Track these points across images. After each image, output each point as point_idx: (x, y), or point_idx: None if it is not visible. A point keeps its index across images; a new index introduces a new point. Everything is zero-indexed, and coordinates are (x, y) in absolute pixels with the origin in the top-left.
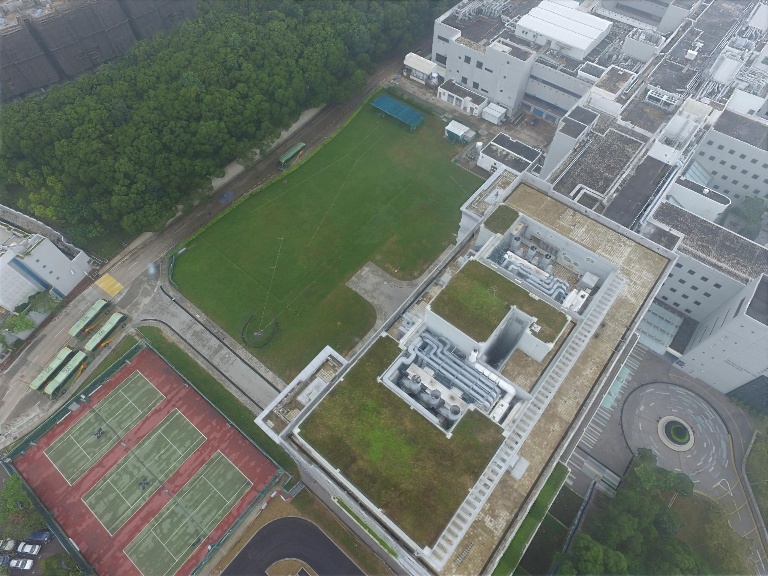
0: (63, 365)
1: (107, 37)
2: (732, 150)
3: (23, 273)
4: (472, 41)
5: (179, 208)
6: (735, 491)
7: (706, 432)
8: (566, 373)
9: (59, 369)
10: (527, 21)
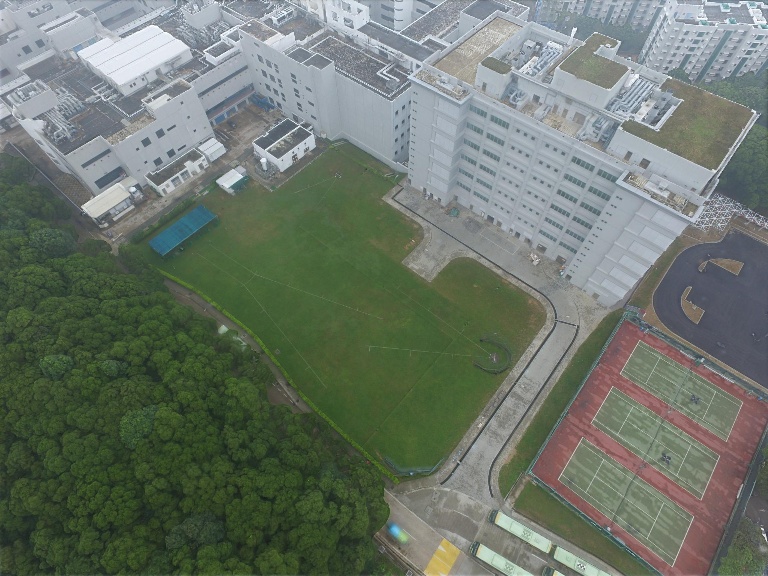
0: None
1: None
2: None
3: None
4: (120, 131)
5: None
6: None
7: None
8: None
9: None
10: (121, 76)
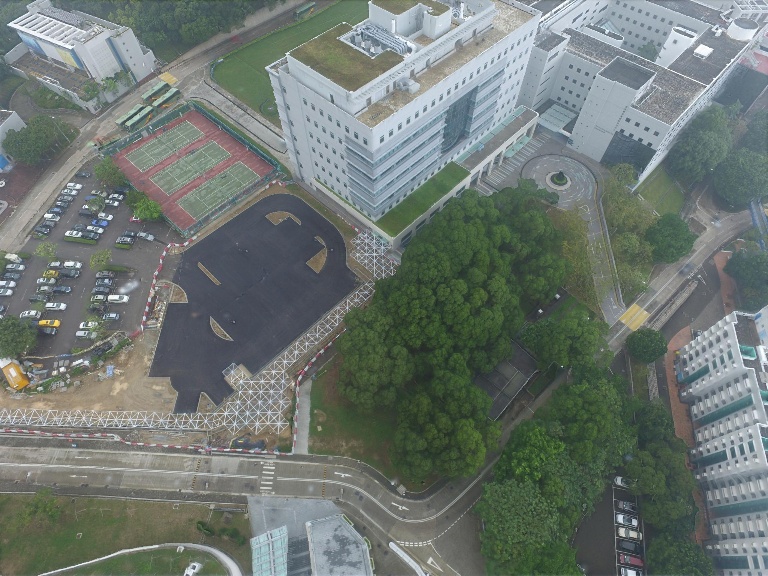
0: None
1: None
2: (633, 7)
3: (113, 53)
4: None
5: (220, 29)
6: (592, 212)
7: (580, 181)
8: (448, 44)
9: None
10: None
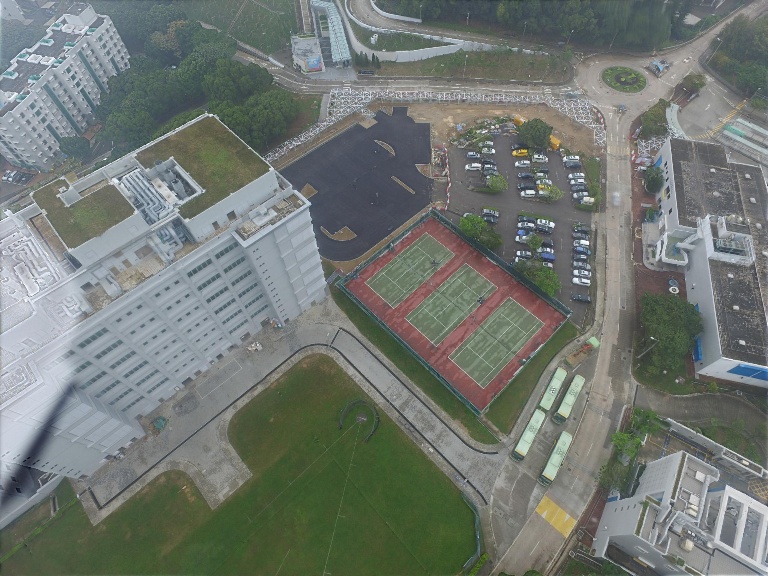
0: None
1: None
2: None
3: None
4: None
5: None
6: None
7: None
8: None
9: None
10: None
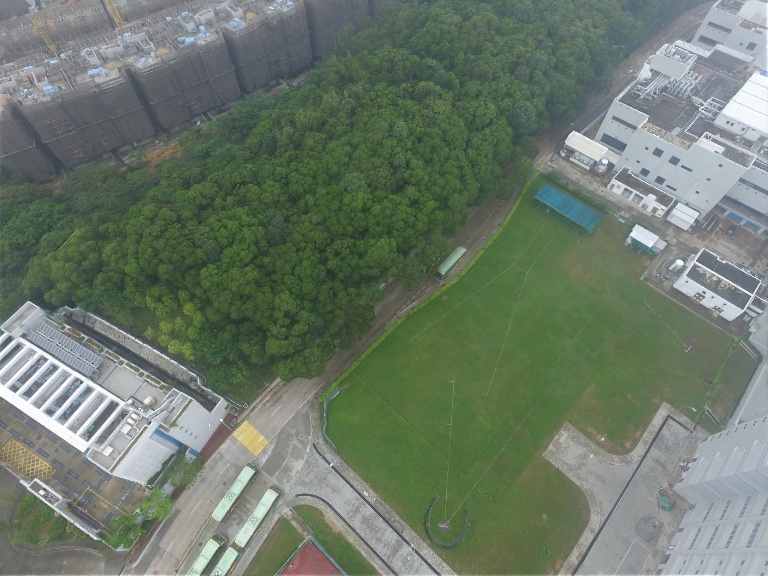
0: (209, 564)
1: (210, 87)
2: None
3: (161, 440)
4: (662, 129)
5: (336, 343)
6: None
7: None
8: None
9: (204, 571)
10: (735, 110)
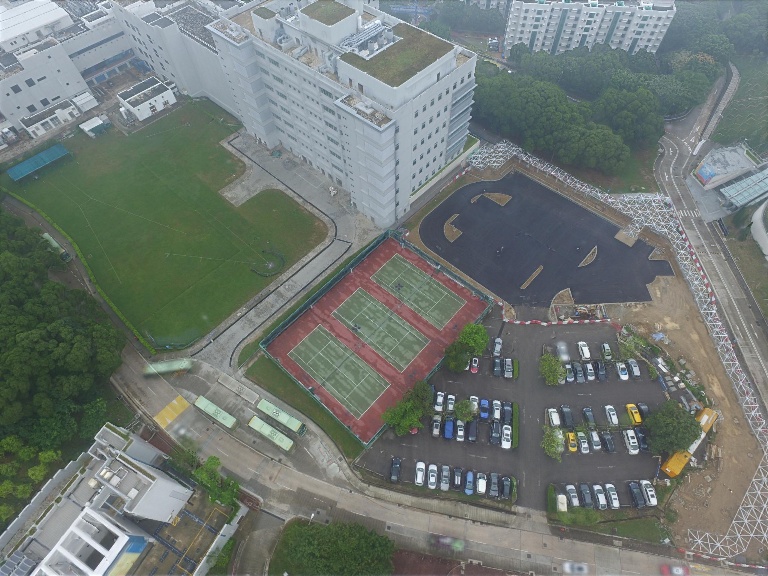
0: None
1: None
2: None
3: None
4: None
5: None
6: None
7: None
8: None
9: None
10: (3, 35)
